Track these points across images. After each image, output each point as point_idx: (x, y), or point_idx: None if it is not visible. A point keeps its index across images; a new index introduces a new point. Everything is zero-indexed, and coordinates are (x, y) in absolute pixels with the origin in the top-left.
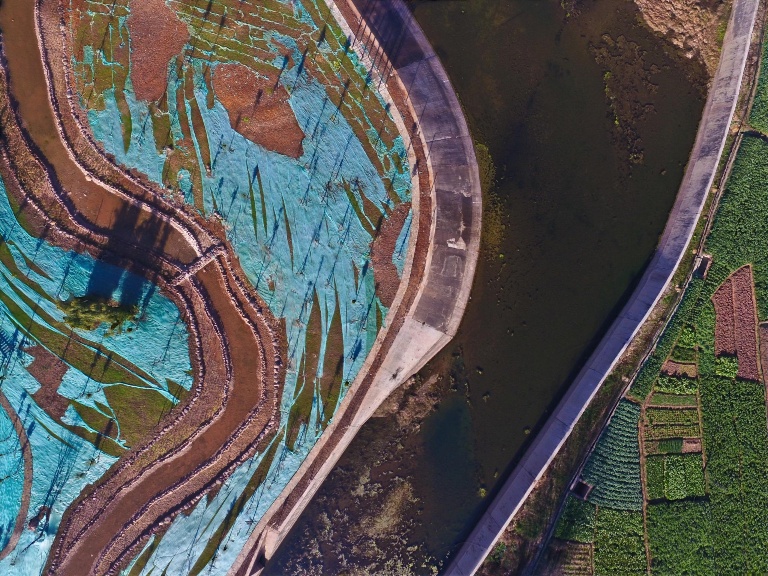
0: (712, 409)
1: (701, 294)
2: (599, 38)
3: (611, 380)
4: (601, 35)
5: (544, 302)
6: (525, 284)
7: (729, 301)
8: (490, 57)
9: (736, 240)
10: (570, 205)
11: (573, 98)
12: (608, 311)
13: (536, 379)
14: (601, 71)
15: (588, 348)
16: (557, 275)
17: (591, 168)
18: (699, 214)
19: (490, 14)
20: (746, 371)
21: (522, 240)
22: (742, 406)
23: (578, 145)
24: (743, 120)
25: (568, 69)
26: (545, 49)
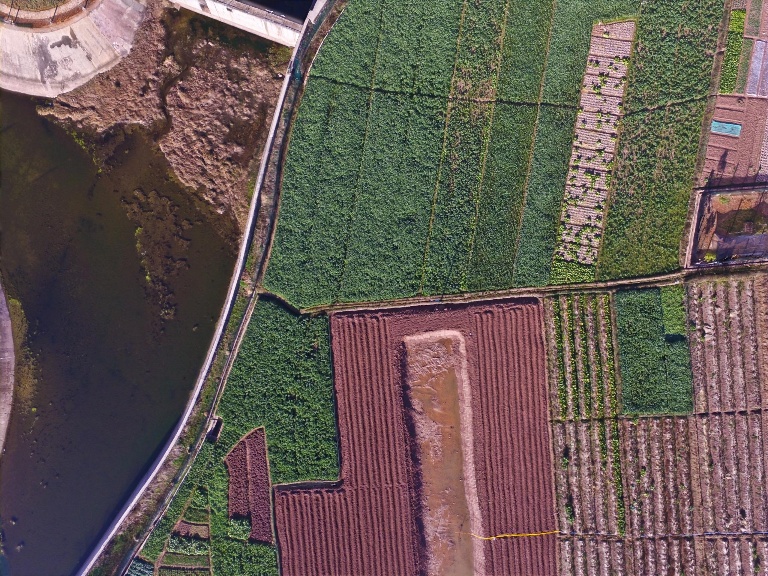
0: (223, 570)
1: (211, 457)
2: (132, 193)
3: (120, 540)
4: (133, 190)
5: (78, 455)
6: (59, 437)
7: (242, 463)
8: (24, 212)
9: (244, 404)
10: (104, 359)
11: (106, 253)
12: (142, 464)
13: (70, 530)
14: (134, 226)
15: (121, 501)
16: (90, 428)
17: (124, 323)
18: (202, 379)
19: (24, 170)
20: (259, 533)
21: (55, 394)
22: (254, 568)
23: (111, 300)
24: (257, 282)
25: (101, 224)
26: (78, 204)
